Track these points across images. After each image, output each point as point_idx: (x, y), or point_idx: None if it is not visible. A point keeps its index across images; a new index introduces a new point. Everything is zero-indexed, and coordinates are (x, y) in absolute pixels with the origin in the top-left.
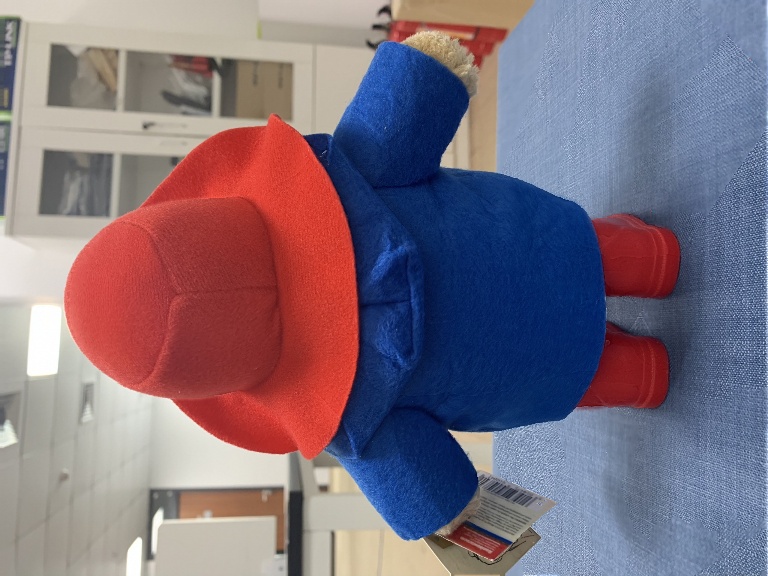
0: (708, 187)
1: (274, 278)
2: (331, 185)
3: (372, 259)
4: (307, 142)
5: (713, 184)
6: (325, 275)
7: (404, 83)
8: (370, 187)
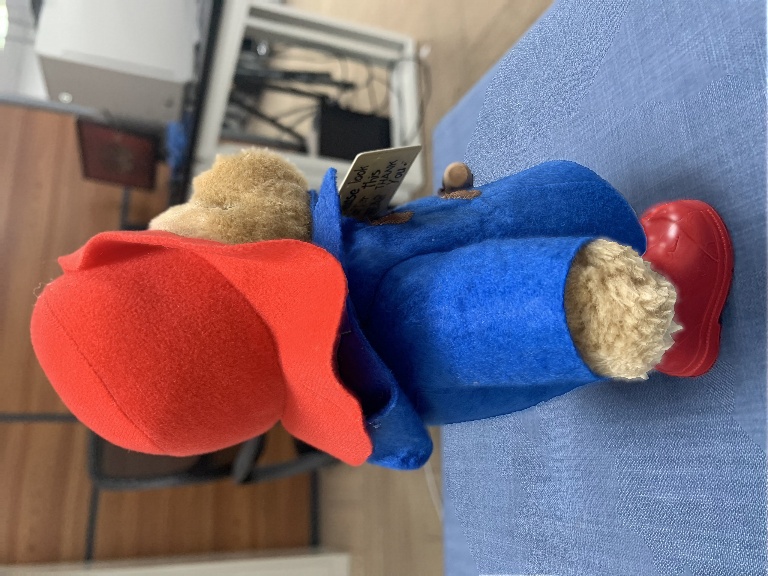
0: (759, 419)
1: (281, 413)
2: (368, 444)
3: (383, 452)
4: (361, 412)
5: (762, 426)
6: (332, 448)
7: (535, 379)
8: (415, 421)
